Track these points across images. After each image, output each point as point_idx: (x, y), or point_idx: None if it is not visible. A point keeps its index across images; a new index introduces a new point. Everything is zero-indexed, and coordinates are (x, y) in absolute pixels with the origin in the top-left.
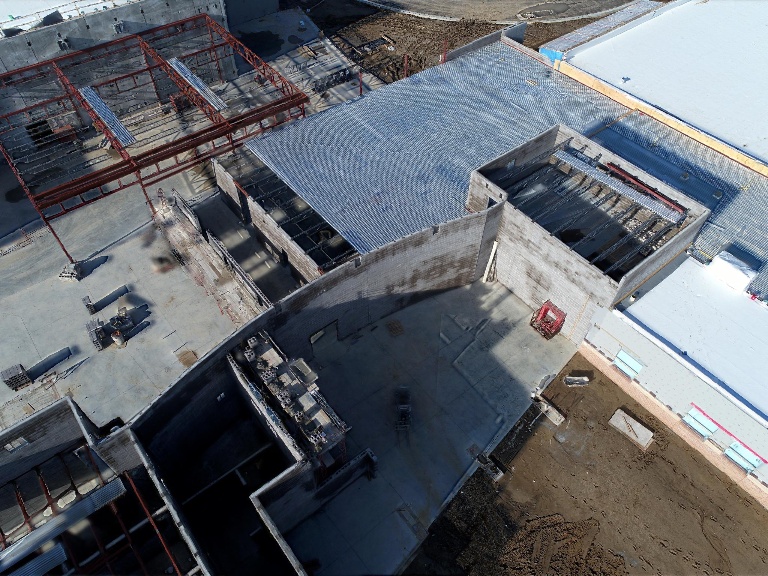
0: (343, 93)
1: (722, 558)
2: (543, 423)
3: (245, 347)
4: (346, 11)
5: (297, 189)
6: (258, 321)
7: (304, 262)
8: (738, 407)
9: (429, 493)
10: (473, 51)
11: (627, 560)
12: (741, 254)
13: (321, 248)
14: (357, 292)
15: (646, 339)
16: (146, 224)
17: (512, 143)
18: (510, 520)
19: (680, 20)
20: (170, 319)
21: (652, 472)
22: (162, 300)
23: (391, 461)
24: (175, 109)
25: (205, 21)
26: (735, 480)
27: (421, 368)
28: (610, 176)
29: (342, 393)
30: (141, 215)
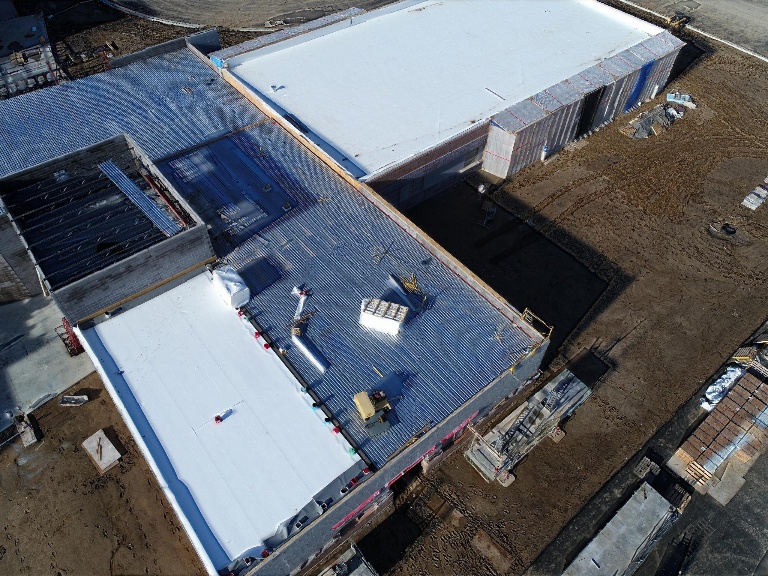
0: None
1: None
2: (13, 445)
3: None
4: (90, 17)
5: None
6: None
7: None
8: None
9: None
10: (150, 58)
11: None
12: (266, 268)
13: None
14: None
15: None
16: None
17: None
18: None
19: (380, 28)
20: None
21: (96, 497)
22: None
23: None
24: None
25: None
26: None
27: None
28: None
29: None
30: None
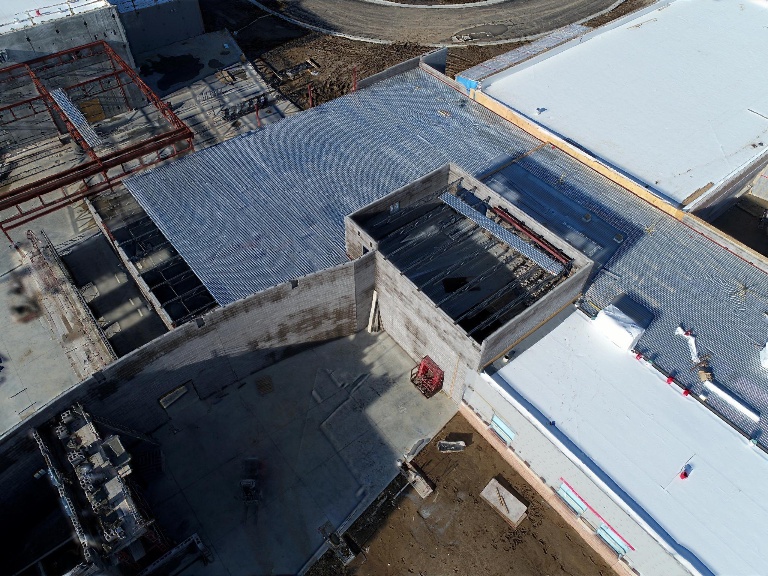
0: (255, 121)
1: None
2: (409, 495)
3: (59, 422)
4: (275, 33)
5: (168, 233)
6: (73, 393)
7: (163, 315)
8: (600, 489)
9: None
10: (388, 79)
11: None
12: (634, 306)
13: (181, 300)
14: (210, 351)
15: (512, 407)
16: (18, 267)
17: (410, 180)
18: None
19: (609, 45)
20: (22, 375)
21: (520, 553)
22: (18, 353)
23: (233, 542)
24: (74, 139)
25: (104, 48)
26: (609, 563)
27: (285, 431)
28: (499, 220)
29: (194, 461)
30: (15, 257)
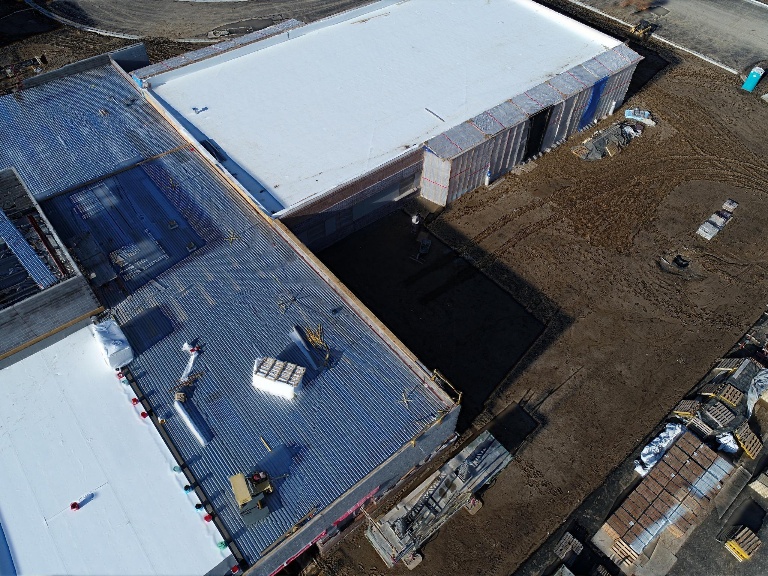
0: None
1: None
2: None
3: None
4: (22, 28)
5: None
6: None
7: None
8: None
9: None
10: (69, 76)
11: None
12: (158, 320)
13: None
14: None
15: None
16: None
17: None
18: None
19: (320, 41)
20: None
21: None
22: None
23: None
24: None
25: None
26: None
27: None
28: None
29: None
30: None
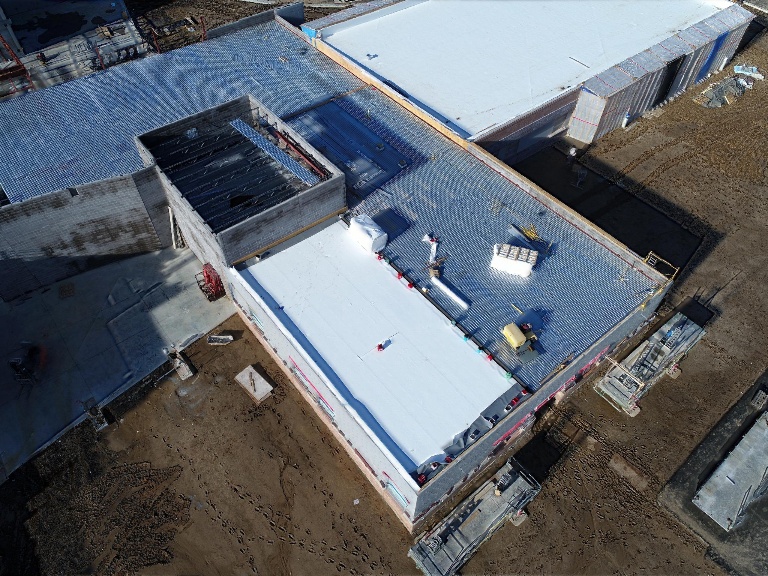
0: None
1: (287, 502)
2: (171, 378)
3: None
4: None
5: None
6: None
7: None
8: (302, 357)
9: (26, 442)
10: (242, 30)
11: (194, 504)
12: (394, 218)
13: None
14: None
15: (249, 295)
16: None
17: None
18: (97, 467)
19: (459, 1)
20: None
21: (256, 424)
22: None
23: (3, 413)
24: None
25: None
26: (331, 431)
27: (74, 327)
28: None
29: None
30: None
